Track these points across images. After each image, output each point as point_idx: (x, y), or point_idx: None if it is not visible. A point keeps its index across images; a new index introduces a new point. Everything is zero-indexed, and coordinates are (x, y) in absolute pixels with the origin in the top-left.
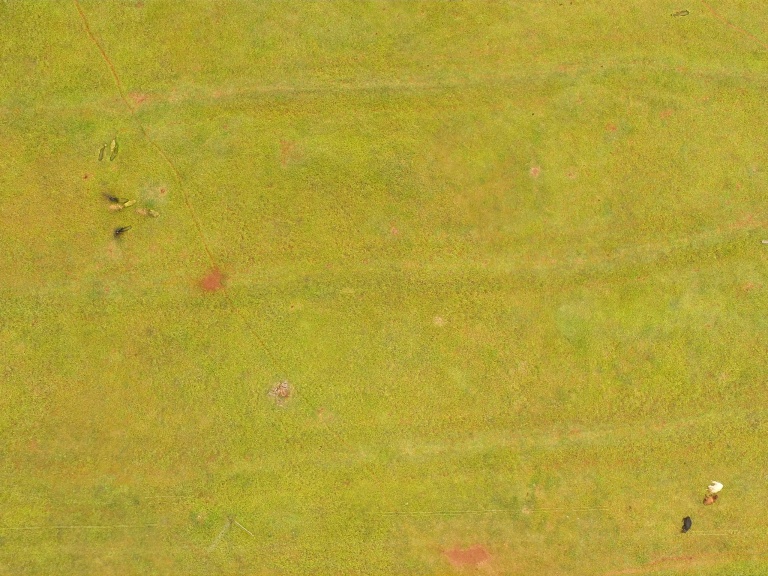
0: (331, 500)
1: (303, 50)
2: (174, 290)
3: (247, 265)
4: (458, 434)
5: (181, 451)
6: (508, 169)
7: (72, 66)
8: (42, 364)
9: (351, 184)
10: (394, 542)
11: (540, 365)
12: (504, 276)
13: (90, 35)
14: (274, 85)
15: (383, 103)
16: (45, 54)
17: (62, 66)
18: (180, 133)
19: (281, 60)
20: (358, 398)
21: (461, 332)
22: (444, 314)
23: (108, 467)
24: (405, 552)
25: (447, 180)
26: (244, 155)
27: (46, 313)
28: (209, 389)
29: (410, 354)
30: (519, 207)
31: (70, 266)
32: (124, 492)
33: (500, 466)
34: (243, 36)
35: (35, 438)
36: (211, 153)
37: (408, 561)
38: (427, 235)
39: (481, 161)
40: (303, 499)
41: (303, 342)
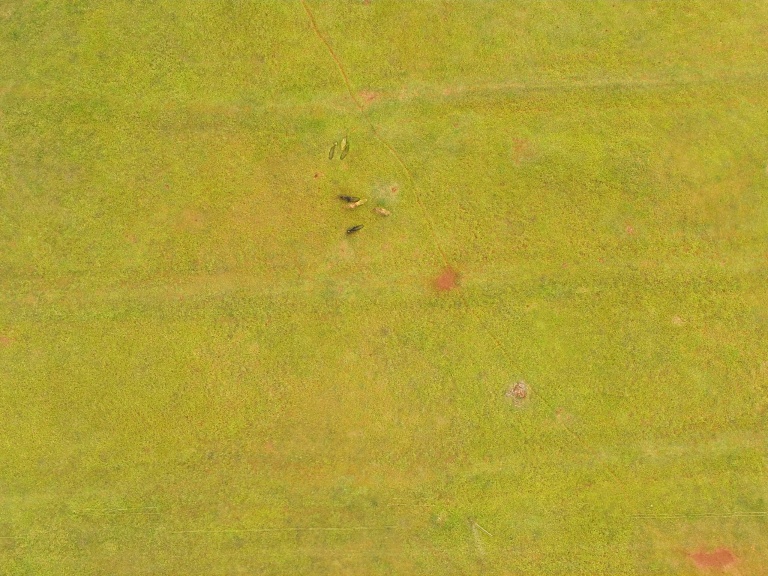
0: (573, 502)
1: (533, 47)
2: (408, 290)
3: (480, 264)
4: (700, 435)
5: (418, 452)
6: (745, 167)
7: (300, 64)
8: (277, 364)
9: (586, 182)
10: (638, 545)
11: None
12: (743, 275)
13: (317, 33)
14: (505, 83)
15: (615, 100)
16: (273, 52)
17: (290, 64)
18: (411, 131)
19: (510, 57)
20: (598, 399)
21: (700, 332)
22: (683, 314)
23: (346, 468)
24: (649, 555)
25: (684, 178)
26: (476, 153)
27: (279, 313)
28: (446, 390)
29: (649, 354)
30: (756, 205)
31: (302, 265)
32: (363, 494)
33: (744, 468)
34: (472, 33)
35: (271, 439)
36: (442, 151)
37: (653, 564)
38: (663, 234)
39: (717, 159)
40: (545, 501)
41: (540, 342)
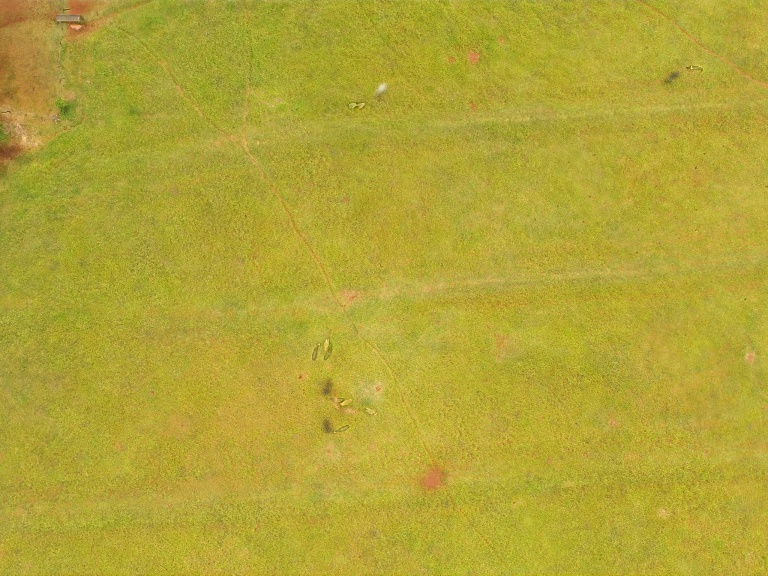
0: None
1: (511, 241)
2: (395, 490)
3: (466, 461)
4: None
5: None
6: (724, 356)
7: (281, 265)
8: (267, 570)
9: (568, 377)
10: None
11: (767, 555)
12: (725, 465)
13: (297, 232)
14: (485, 278)
15: (594, 292)
16: (253, 253)
17: (271, 265)
18: (393, 330)
19: (489, 251)
20: None
21: (685, 524)
22: (668, 506)
23: None
24: None
25: (664, 370)
26: (458, 350)
27: (268, 517)
28: None
29: (635, 548)
30: (736, 394)
31: (289, 468)
32: None
33: None
34: (450, 228)
35: None
36: (425, 349)
37: None
38: (645, 425)
39: (696, 349)
40: None
41: (528, 539)
